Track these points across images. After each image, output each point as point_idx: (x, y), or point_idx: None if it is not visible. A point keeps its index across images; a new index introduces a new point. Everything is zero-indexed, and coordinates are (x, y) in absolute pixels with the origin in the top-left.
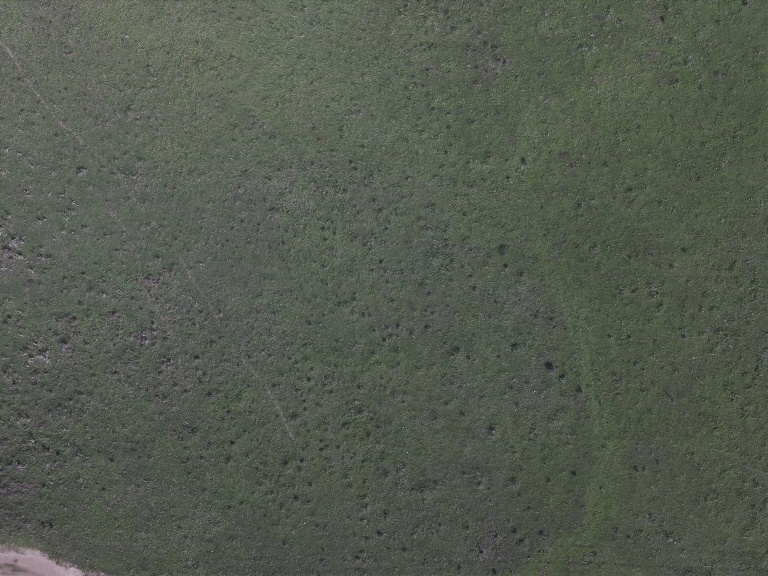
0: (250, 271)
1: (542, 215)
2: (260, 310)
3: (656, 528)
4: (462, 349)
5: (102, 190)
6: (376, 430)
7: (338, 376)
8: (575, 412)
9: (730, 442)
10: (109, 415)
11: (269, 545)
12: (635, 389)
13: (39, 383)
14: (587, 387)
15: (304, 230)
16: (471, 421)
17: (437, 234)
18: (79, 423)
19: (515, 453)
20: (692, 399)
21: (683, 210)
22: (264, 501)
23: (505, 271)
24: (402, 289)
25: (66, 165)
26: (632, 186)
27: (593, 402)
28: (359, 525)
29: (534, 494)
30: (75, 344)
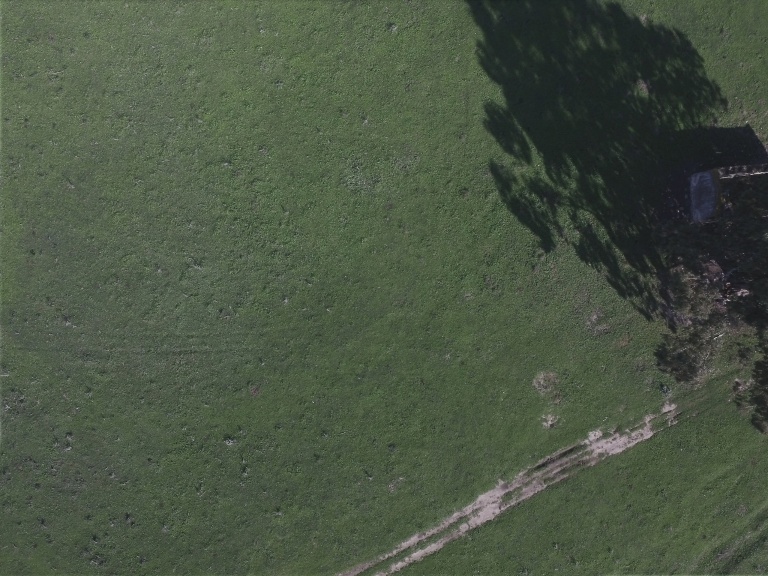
0: None
1: None
2: None
3: (55, 312)
4: None
5: None
6: None
7: None
8: None
9: (132, 226)
10: None
11: None
12: (32, 173)
13: None
14: None
15: None
16: None
17: None
18: None
19: None
20: (94, 184)
21: None
22: None
23: None
24: None
25: None
26: None
27: None
28: None
29: None
30: None
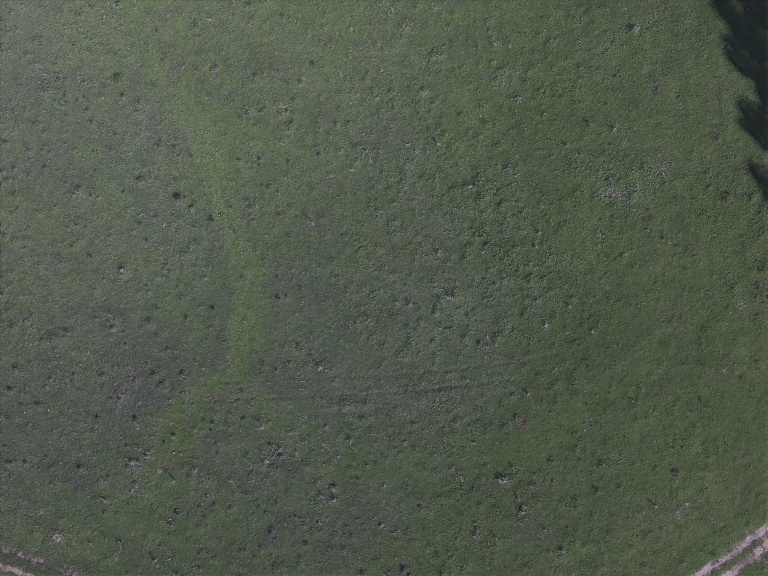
0: None
1: (157, 39)
2: None
3: (305, 357)
4: (84, 187)
5: None
6: None
7: None
8: (209, 243)
9: (377, 260)
10: None
11: None
12: (270, 213)
13: None
14: (220, 215)
15: None
16: (99, 262)
17: (47, 68)
18: None
19: (148, 291)
20: (333, 219)
21: (308, 21)
22: None
23: (122, 101)
24: (14, 129)
25: None
26: (251, 0)
27: (227, 230)
28: None
29: (172, 333)
30: None
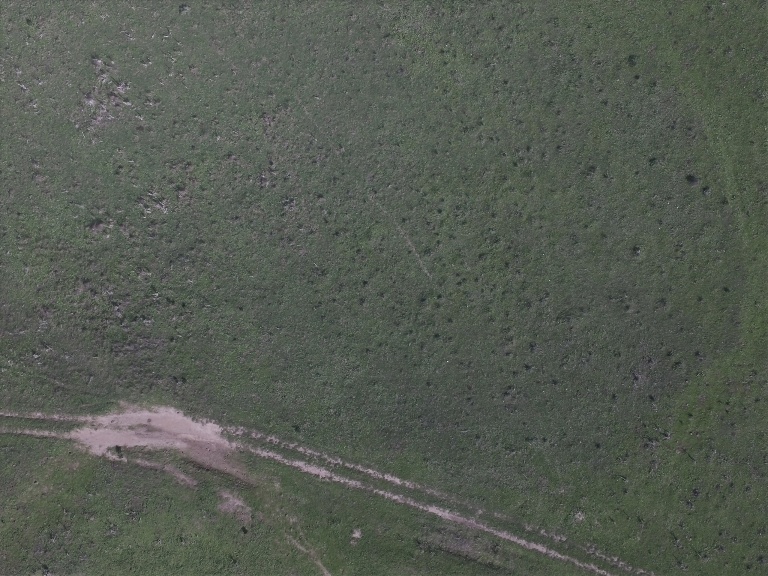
0: (369, 102)
1: (671, 22)
2: (383, 142)
3: None
4: (598, 168)
5: (208, 28)
6: (515, 259)
7: (470, 206)
8: (722, 225)
9: None
10: (234, 263)
11: (413, 387)
12: None
13: (157, 235)
14: (733, 198)
15: (422, 56)
16: (614, 243)
17: (562, 50)
18: (203, 273)
19: (663, 272)
20: None
21: None
22: (404, 341)
23: (637, 83)
24: (530, 110)
25: (168, 5)
26: None
27: (741, 213)
28: (505, 360)
29: (686, 314)
30: (192, 191)
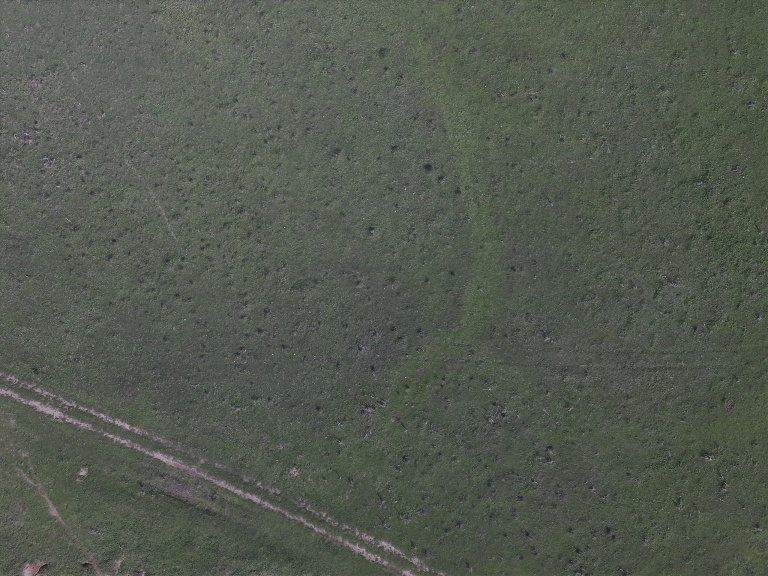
0: (133, 73)
1: (423, 19)
2: (143, 111)
3: (533, 328)
4: (343, 151)
5: None
6: (257, 230)
7: (220, 177)
8: (454, 213)
9: (607, 244)
10: None
11: (150, 341)
12: (513, 191)
13: None
14: (466, 189)
15: (187, 33)
16: (351, 222)
17: (319, 38)
18: None
19: (394, 253)
20: (570, 202)
21: (562, 16)
22: (145, 298)
23: (386, 74)
24: (284, 92)
25: None
26: None
27: (472, 203)
28: (239, 322)
29: (413, 293)
30: None
